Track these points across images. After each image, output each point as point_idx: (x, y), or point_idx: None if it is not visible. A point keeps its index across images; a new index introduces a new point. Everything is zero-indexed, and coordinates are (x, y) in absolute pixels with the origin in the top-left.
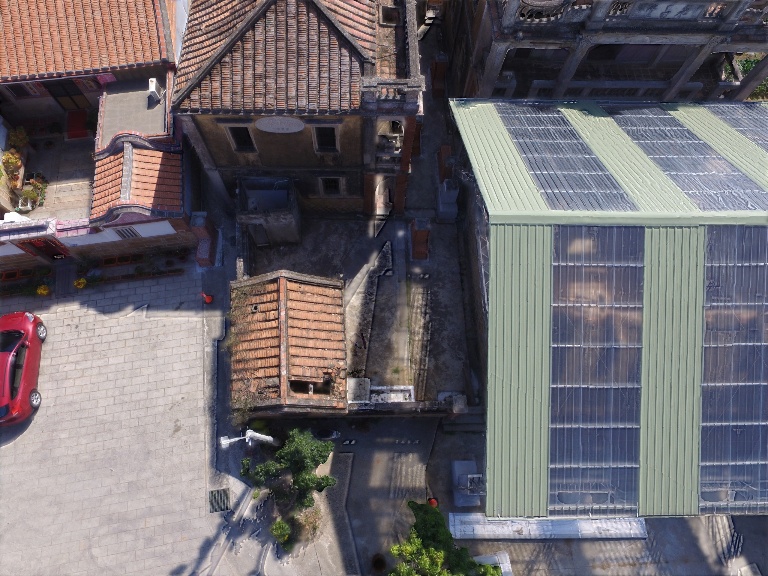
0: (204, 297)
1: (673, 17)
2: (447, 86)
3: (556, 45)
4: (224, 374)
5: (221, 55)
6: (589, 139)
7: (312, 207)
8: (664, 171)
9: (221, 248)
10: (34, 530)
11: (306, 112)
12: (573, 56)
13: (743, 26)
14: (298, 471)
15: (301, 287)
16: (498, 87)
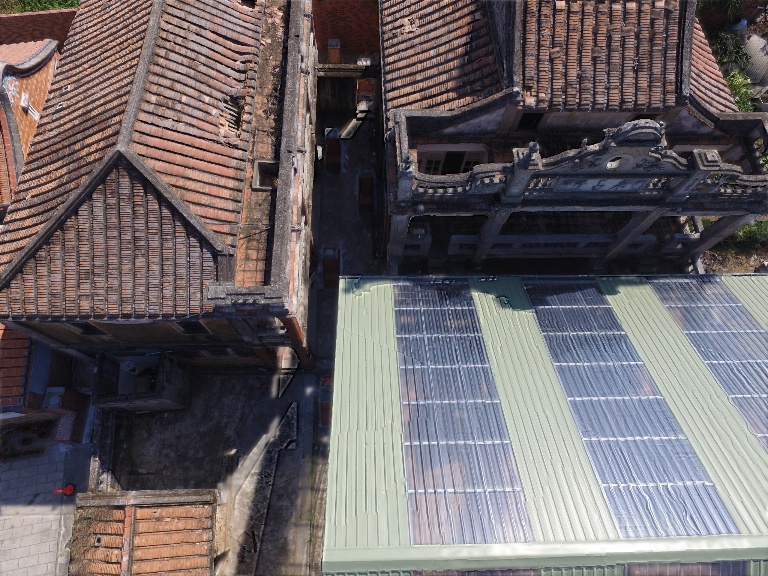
0: (65, 486)
1: (608, 189)
2: (376, 197)
3: (469, 213)
4: None
5: (34, 249)
6: (498, 360)
7: (204, 363)
8: (583, 435)
9: (92, 418)
10: None
11: (146, 316)
12: (492, 222)
13: (696, 195)
14: None
15: (157, 512)
16: (410, 244)
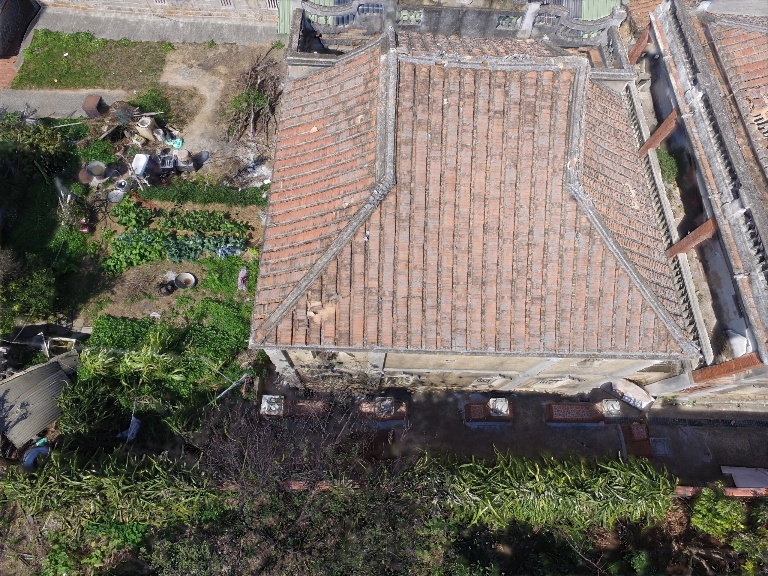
0: None
1: None
2: None
3: None
4: None
5: None
6: None
7: None
8: None
9: None
10: None
11: None
12: None
13: None
14: None
15: None
16: None
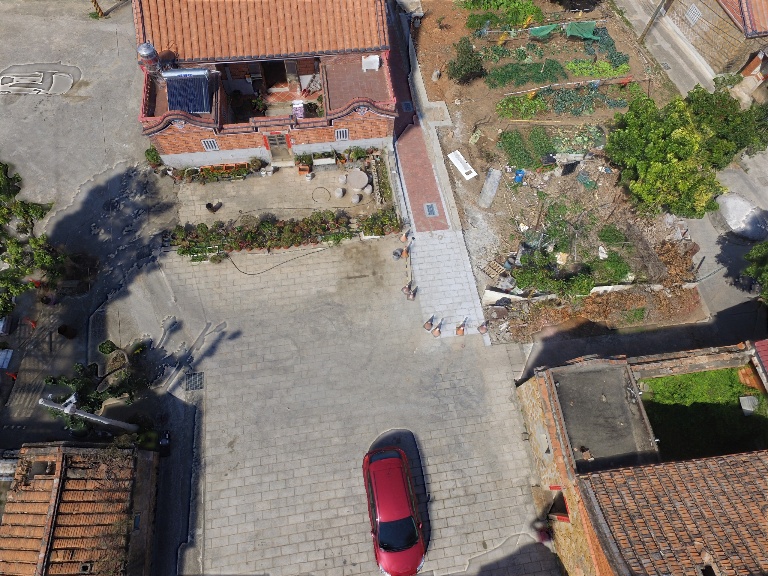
0: None
1: None
2: None
3: None
4: (183, 501)
5: None
6: None
7: None
8: None
9: None
10: (344, 364)
11: None
12: None
13: None
14: (80, 391)
15: None
16: None
